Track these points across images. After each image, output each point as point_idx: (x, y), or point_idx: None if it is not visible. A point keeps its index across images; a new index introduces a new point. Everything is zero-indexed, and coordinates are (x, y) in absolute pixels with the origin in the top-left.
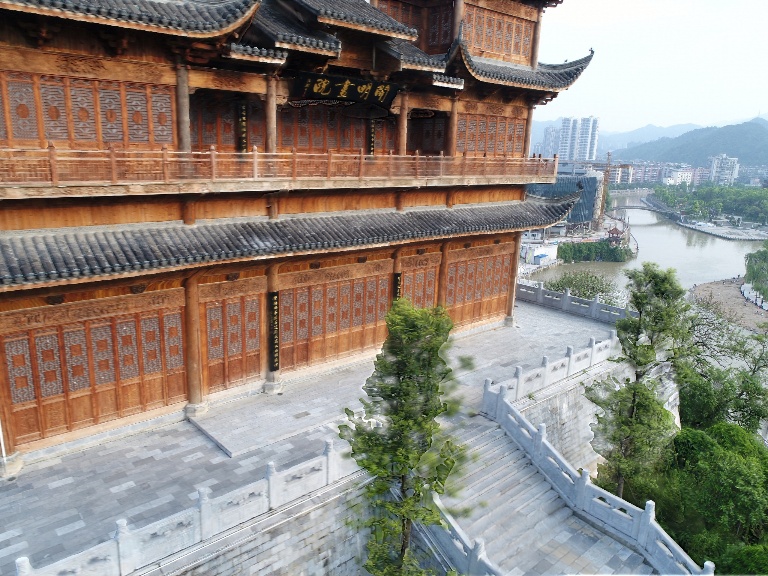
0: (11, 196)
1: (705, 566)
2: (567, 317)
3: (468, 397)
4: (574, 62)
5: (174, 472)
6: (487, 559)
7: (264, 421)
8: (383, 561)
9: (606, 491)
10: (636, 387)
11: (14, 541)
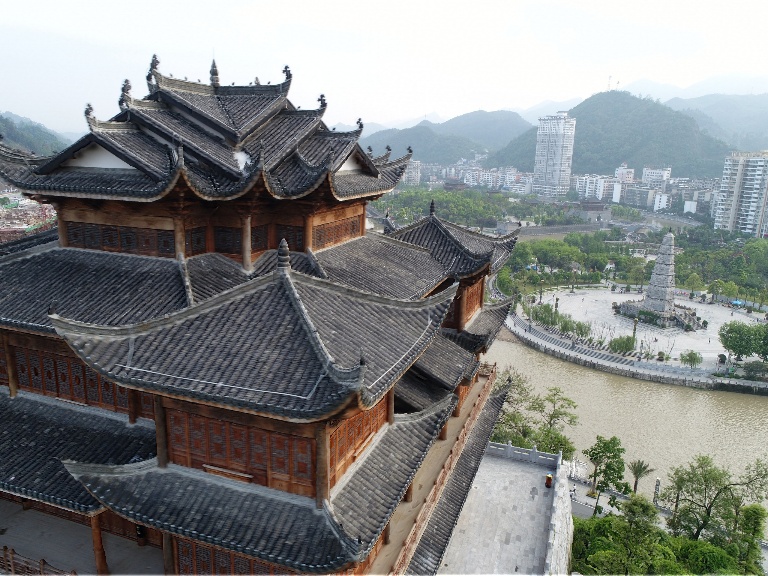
0: None
1: None
2: (492, 461)
3: None
4: (506, 301)
5: None
6: None
7: None
8: None
9: None
10: (633, 569)
11: None
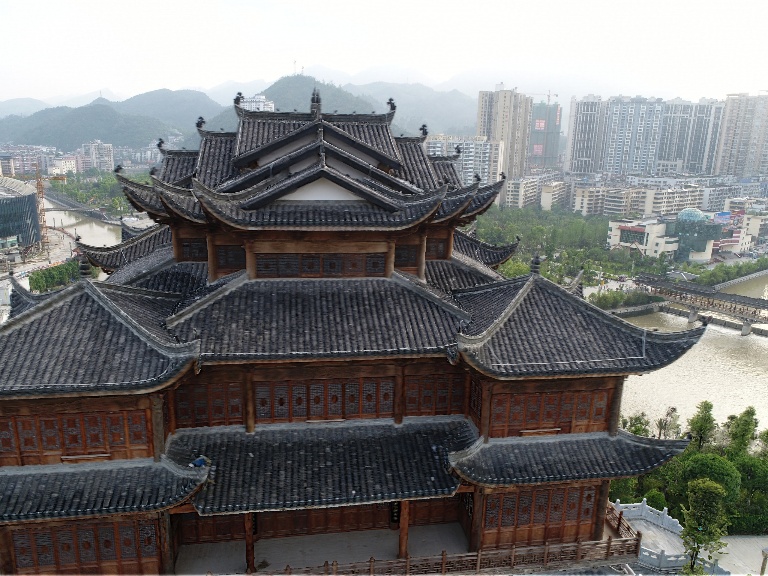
0: None
1: (666, 510)
2: None
3: None
4: None
5: None
6: (667, 554)
7: None
8: (693, 573)
9: (627, 504)
10: None
11: None
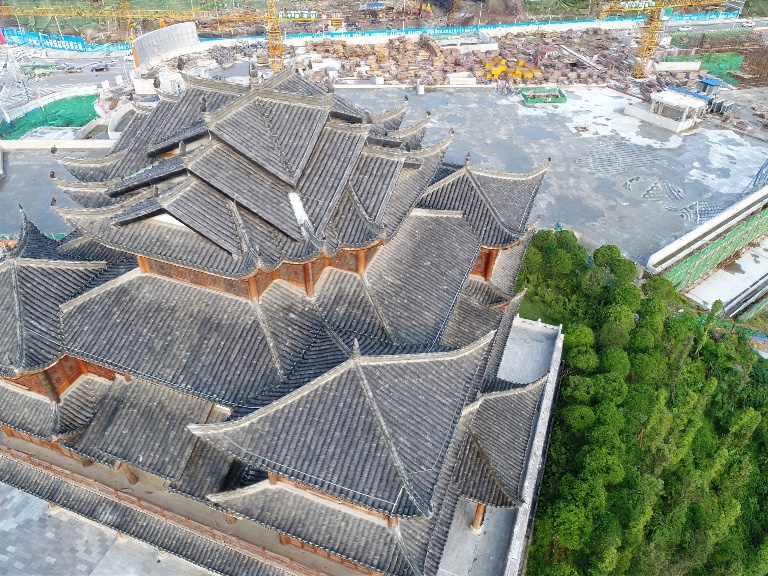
0: (3, 456)
1: None
2: None
3: None
4: (413, 564)
5: (66, 570)
6: None
7: (121, 575)
8: None
9: None
10: None
11: None
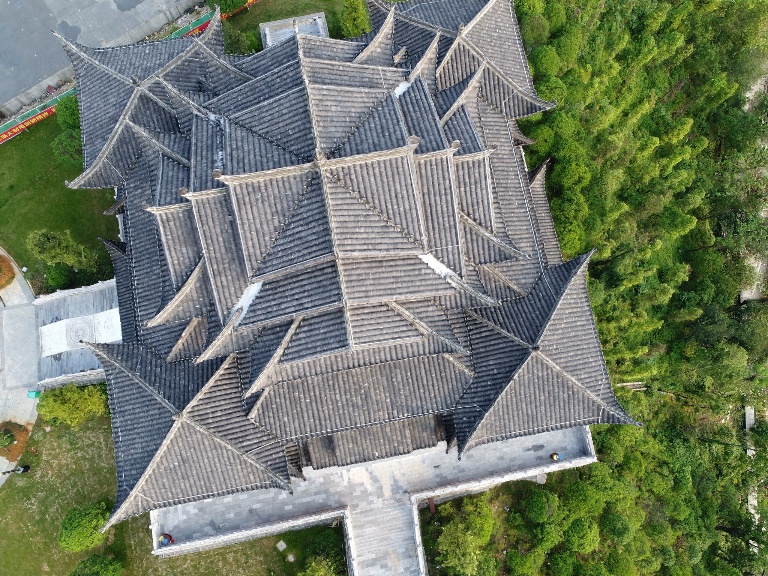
0: None
1: None
2: None
3: (415, 475)
4: None
5: None
6: (354, 565)
7: None
8: None
9: (420, 556)
10: None
11: (228, 496)
